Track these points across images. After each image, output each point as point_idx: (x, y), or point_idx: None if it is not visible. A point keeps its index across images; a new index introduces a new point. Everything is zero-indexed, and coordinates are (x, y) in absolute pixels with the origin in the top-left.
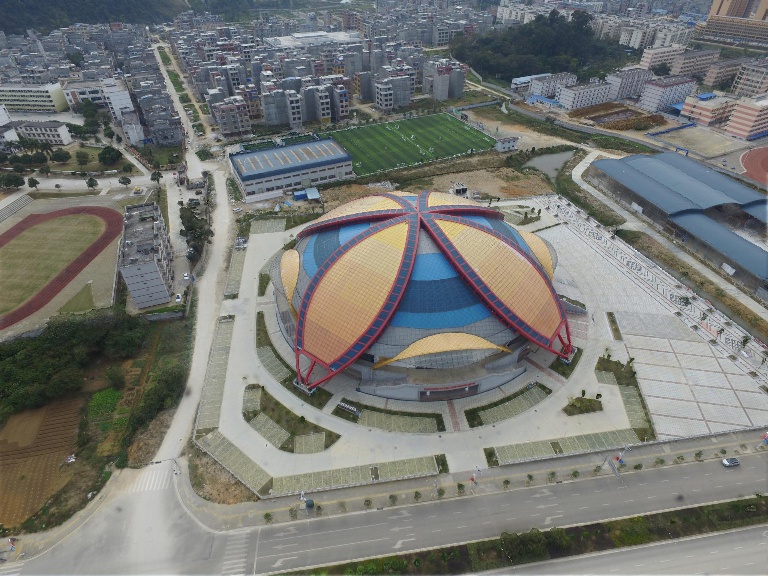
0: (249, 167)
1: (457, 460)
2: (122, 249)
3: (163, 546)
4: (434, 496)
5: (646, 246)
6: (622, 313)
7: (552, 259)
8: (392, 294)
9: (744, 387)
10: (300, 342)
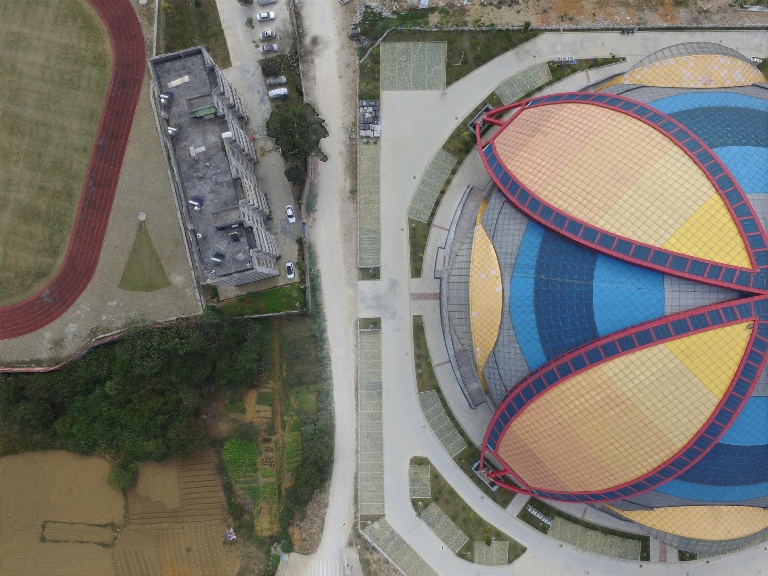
0: None
1: None
2: (190, 227)
3: None
4: None
5: None
6: None
7: None
8: (668, 468)
9: None
10: (493, 444)
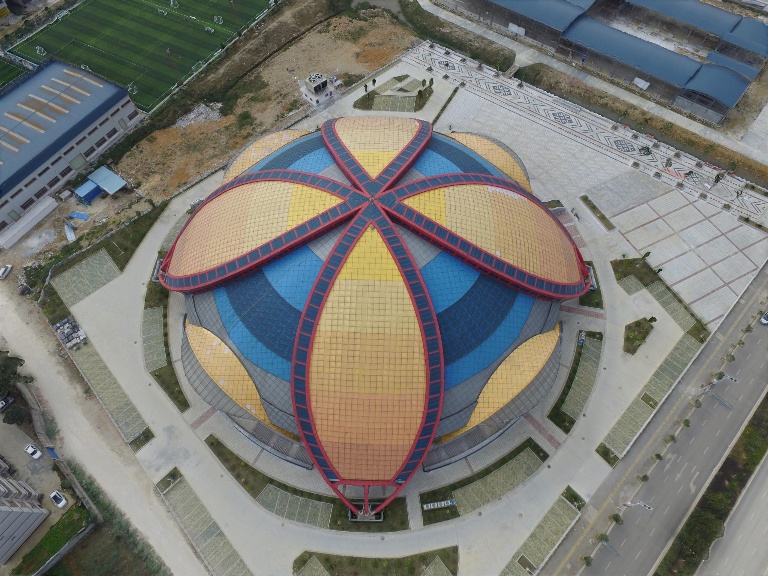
0: None
1: (583, 483)
2: None
3: None
4: (594, 542)
5: (554, 83)
6: (592, 191)
7: (520, 167)
8: (430, 355)
9: (729, 226)
10: (331, 474)
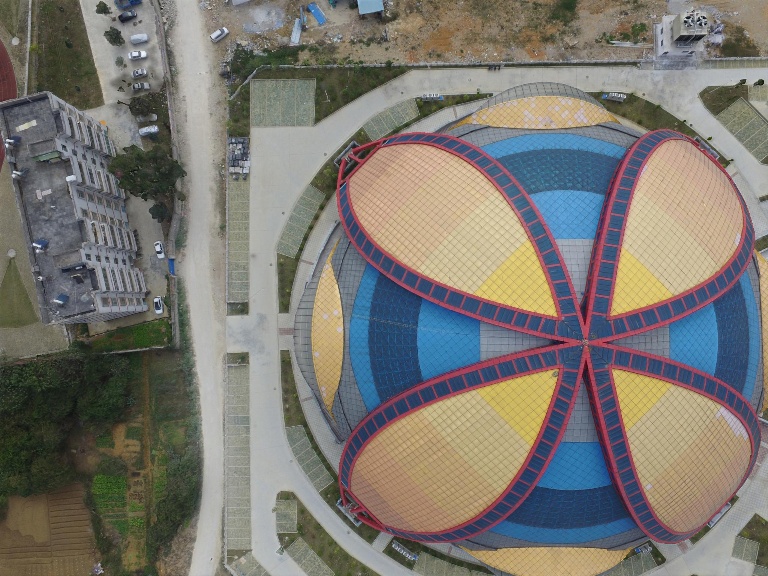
0: None
1: None
2: (33, 269)
3: None
4: None
5: None
6: None
7: None
8: (492, 512)
9: None
10: (345, 482)
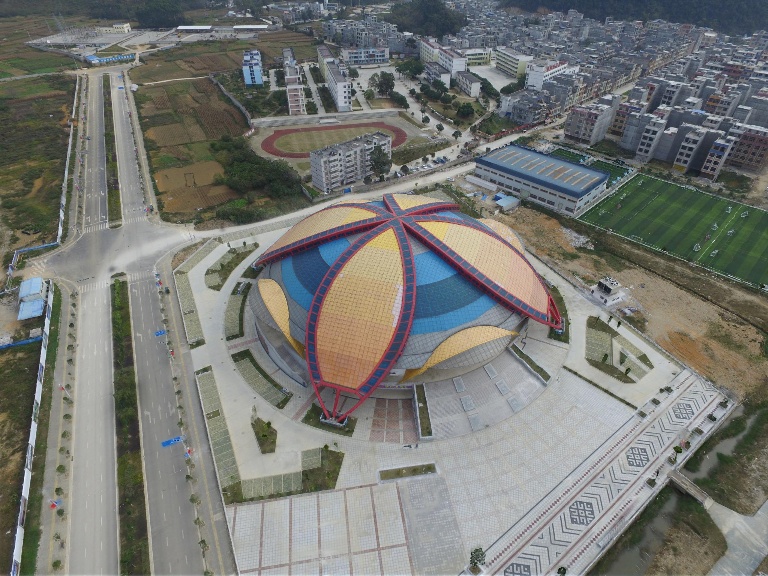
0: (498, 156)
1: (201, 352)
2: (328, 146)
3: (149, 252)
4: None
5: (674, 544)
6: (441, 484)
7: (449, 360)
8: (297, 242)
9: None
10: None
